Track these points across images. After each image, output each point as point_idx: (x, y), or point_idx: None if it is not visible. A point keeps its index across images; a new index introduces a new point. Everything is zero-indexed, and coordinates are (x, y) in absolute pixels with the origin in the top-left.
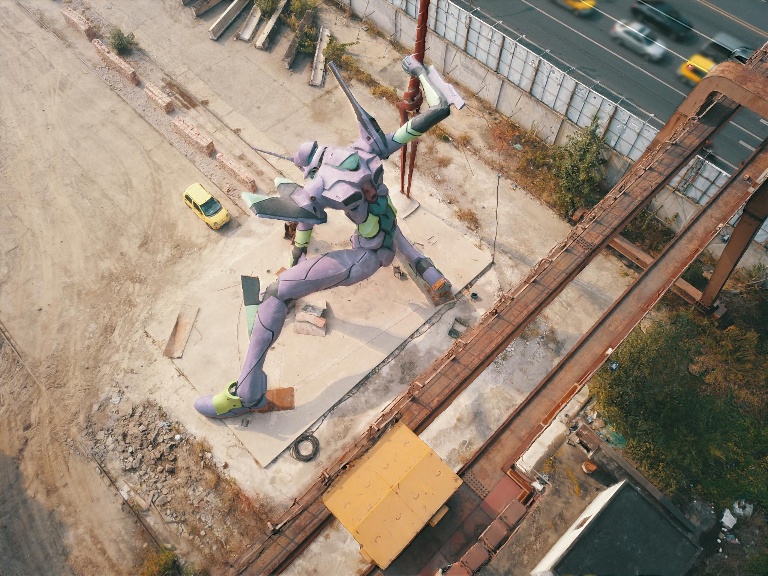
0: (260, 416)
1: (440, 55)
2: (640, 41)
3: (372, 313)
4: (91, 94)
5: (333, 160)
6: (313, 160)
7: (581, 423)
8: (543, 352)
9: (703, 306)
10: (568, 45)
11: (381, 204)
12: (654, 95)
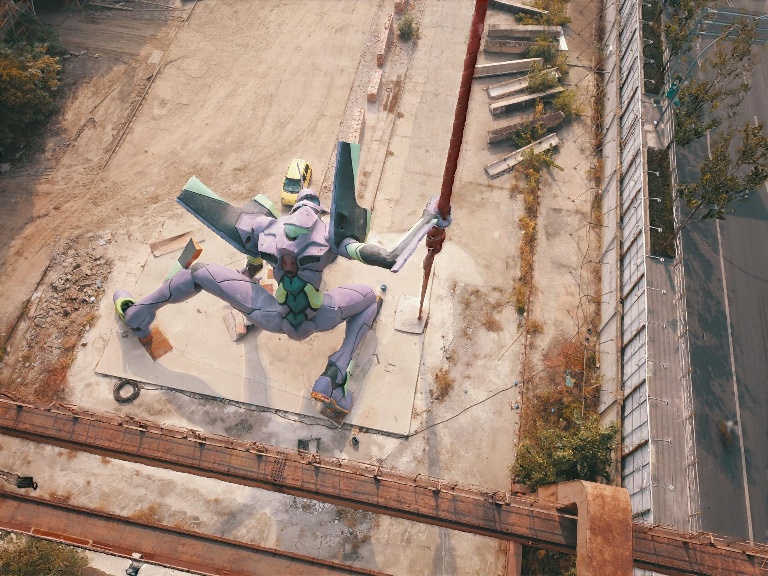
0: (136, 341)
1: None
2: None
3: (279, 364)
4: (347, 48)
5: None
6: None
7: None
8: (335, 543)
9: None
10: (764, 353)
11: (294, 284)
12: None
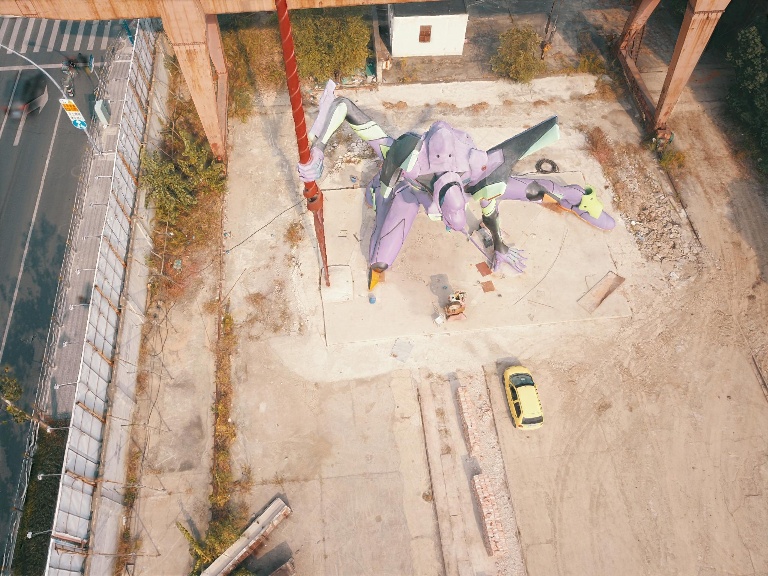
0: None
1: (124, 405)
2: None
3: None
4: None
5: None
6: None
7: (369, 81)
8: (347, 124)
9: (228, 71)
10: None
11: None
12: (1, 224)
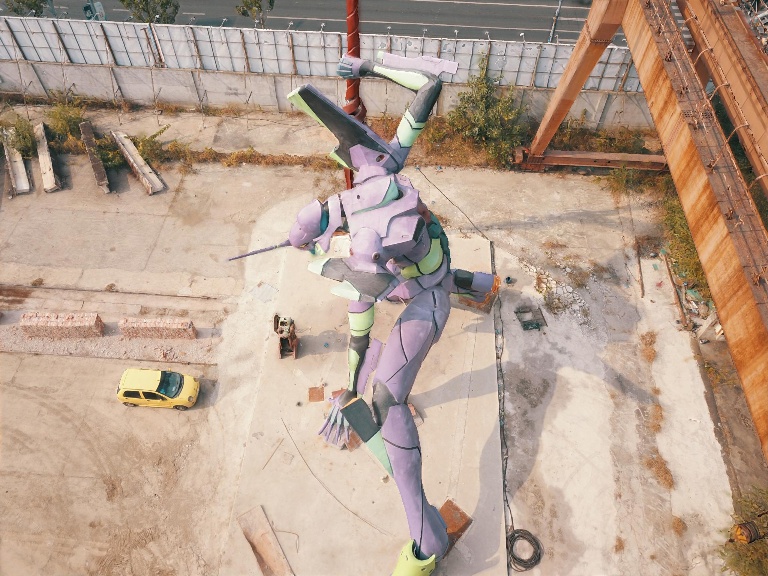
0: (448, 561)
1: (268, 93)
2: (414, 5)
3: (442, 364)
4: None
5: (368, 201)
6: (332, 220)
7: (695, 319)
8: (606, 286)
9: None
10: None
11: (436, 222)
12: None
